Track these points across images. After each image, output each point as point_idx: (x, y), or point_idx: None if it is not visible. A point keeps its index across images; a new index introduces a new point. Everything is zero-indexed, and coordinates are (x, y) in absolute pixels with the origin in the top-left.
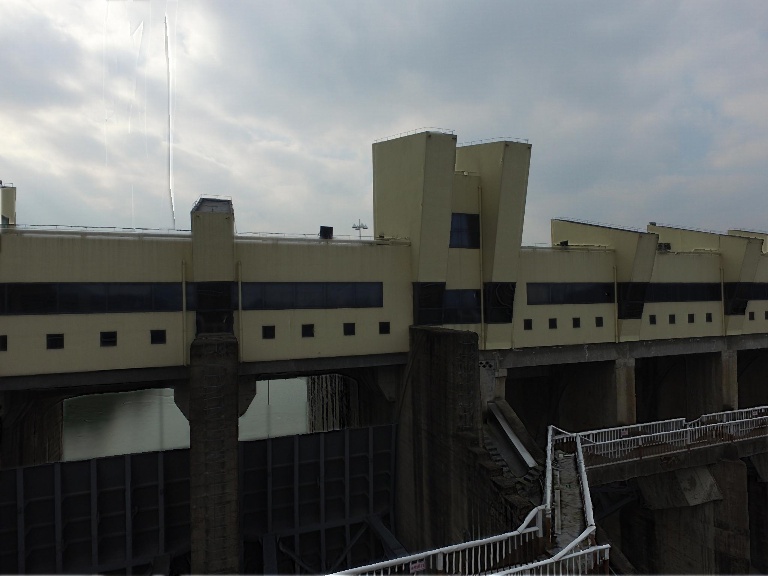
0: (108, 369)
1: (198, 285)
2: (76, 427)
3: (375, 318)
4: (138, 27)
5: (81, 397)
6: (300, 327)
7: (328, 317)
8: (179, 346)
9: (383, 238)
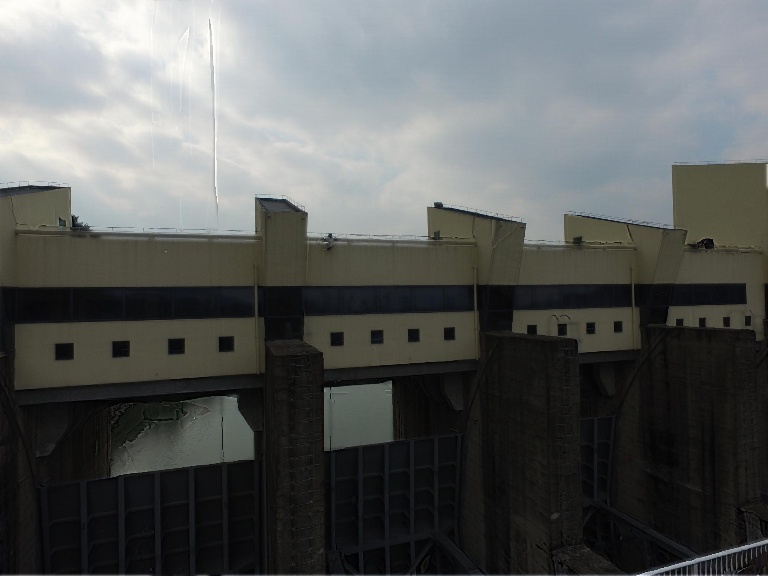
0: (591, 351)
1: (654, 286)
2: (237, 415)
3: (742, 313)
4: (184, 33)
5: None
6: (698, 320)
7: (714, 312)
8: (630, 334)
9: (744, 247)
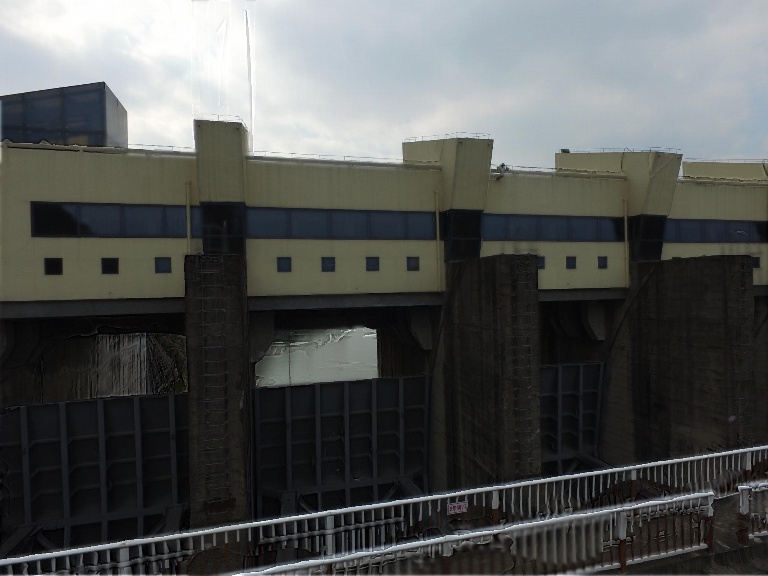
0: None
1: None
2: None
3: None
4: (222, 24)
5: (270, 363)
6: None
7: None
8: (767, 270)
9: None
